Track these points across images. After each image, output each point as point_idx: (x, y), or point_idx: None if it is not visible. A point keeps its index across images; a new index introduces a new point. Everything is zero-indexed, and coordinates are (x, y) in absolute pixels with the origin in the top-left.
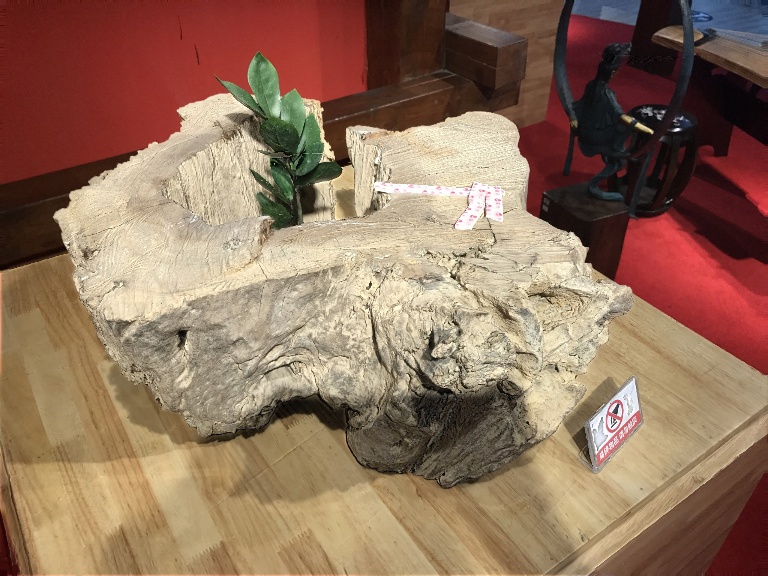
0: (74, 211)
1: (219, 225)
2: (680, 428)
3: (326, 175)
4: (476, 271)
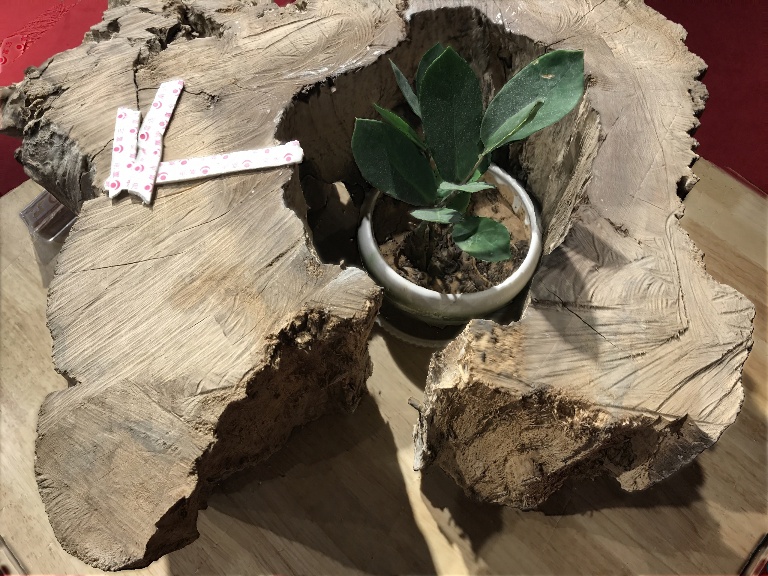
0: (666, 35)
1: (461, 5)
2: None
3: (381, 162)
4: (162, 6)
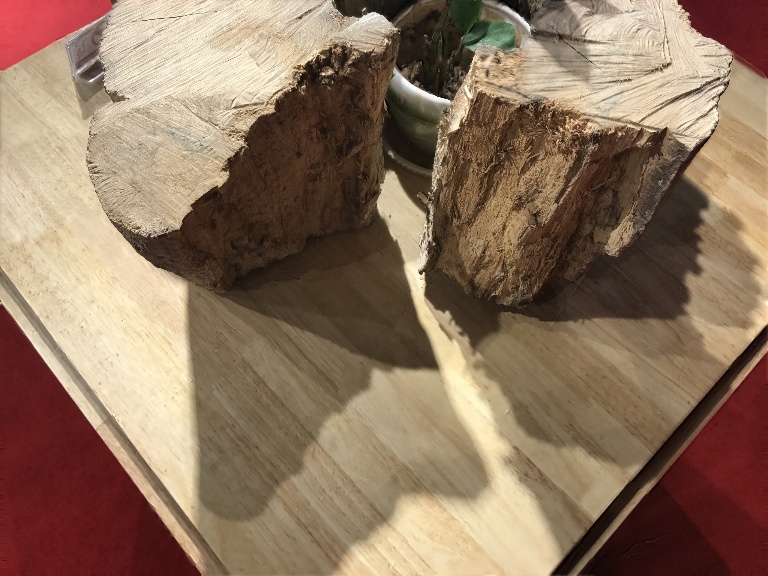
0: None
1: None
2: (39, 73)
3: None
4: None
